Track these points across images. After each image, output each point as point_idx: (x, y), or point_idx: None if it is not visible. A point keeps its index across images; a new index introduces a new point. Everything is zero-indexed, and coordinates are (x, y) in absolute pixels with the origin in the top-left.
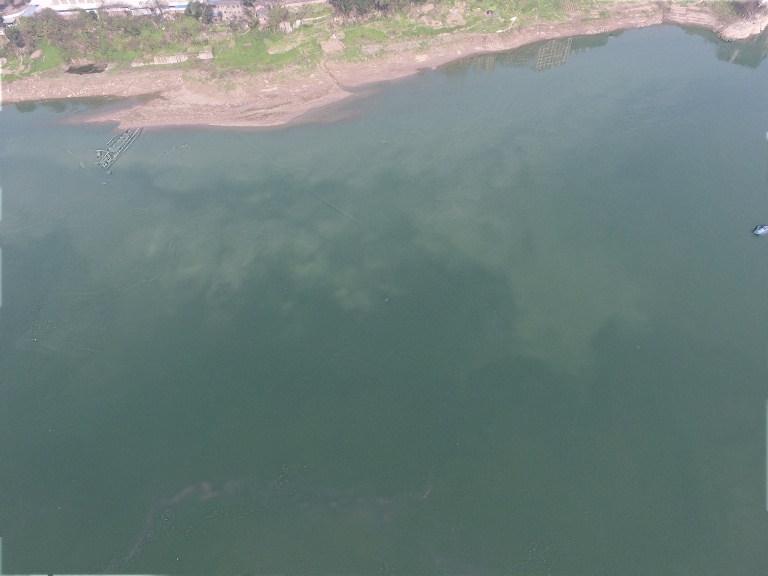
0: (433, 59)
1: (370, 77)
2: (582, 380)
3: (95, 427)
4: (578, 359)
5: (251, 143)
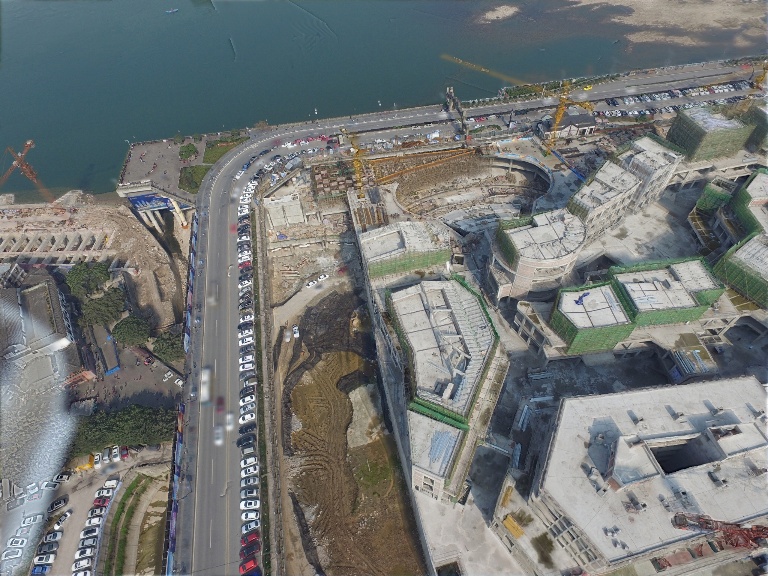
0: None
1: None
2: None
3: None
4: (26, 57)
5: None
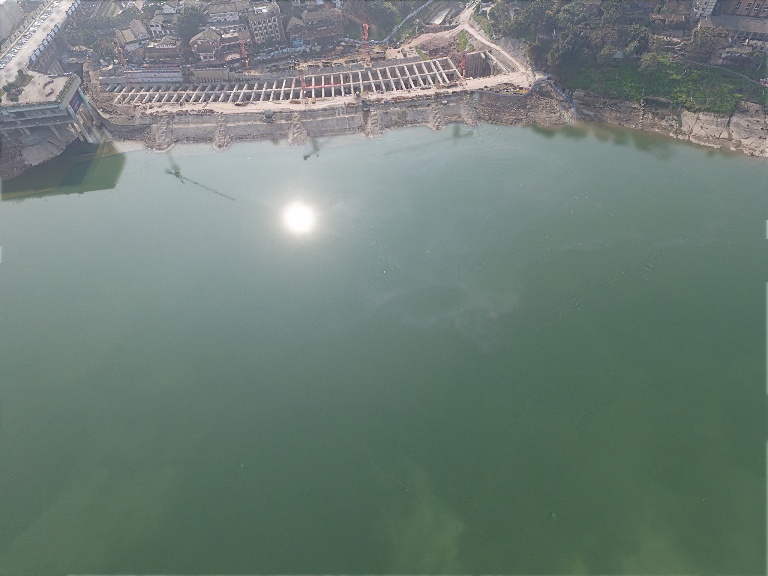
0: None
1: None
2: (318, 418)
3: (766, 325)
4: (316, 441)
5: None
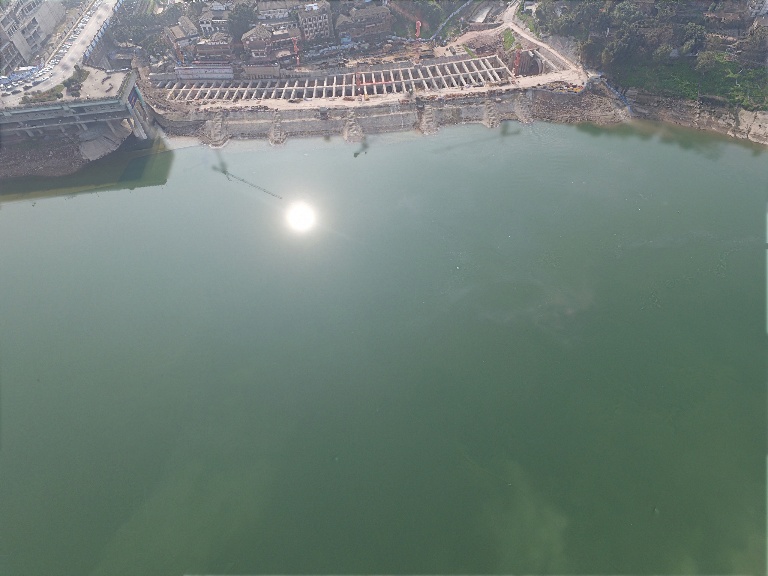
0: None
1: None
2: (408, 412)
3: None
4: (408, 436)
5: None
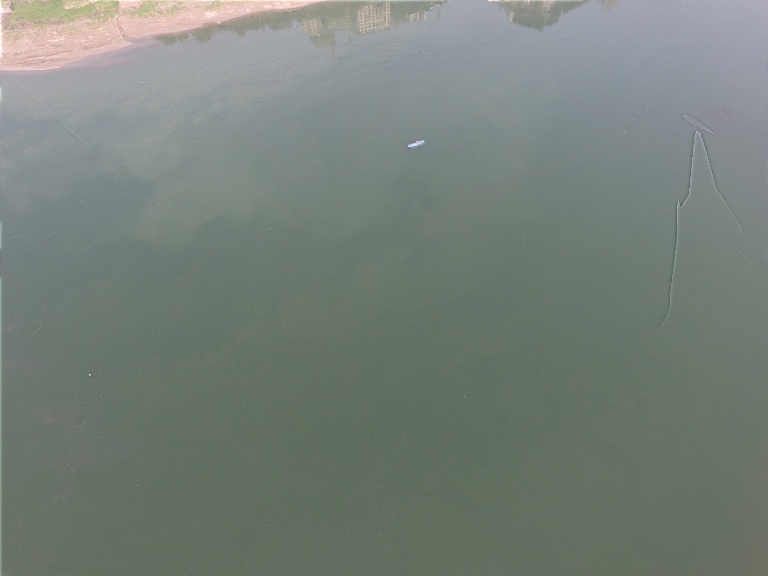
0: (221, 15)
1: (156, 30)
2: (210, 252)
3: None
4: (214, 238)
5: (22, 85)
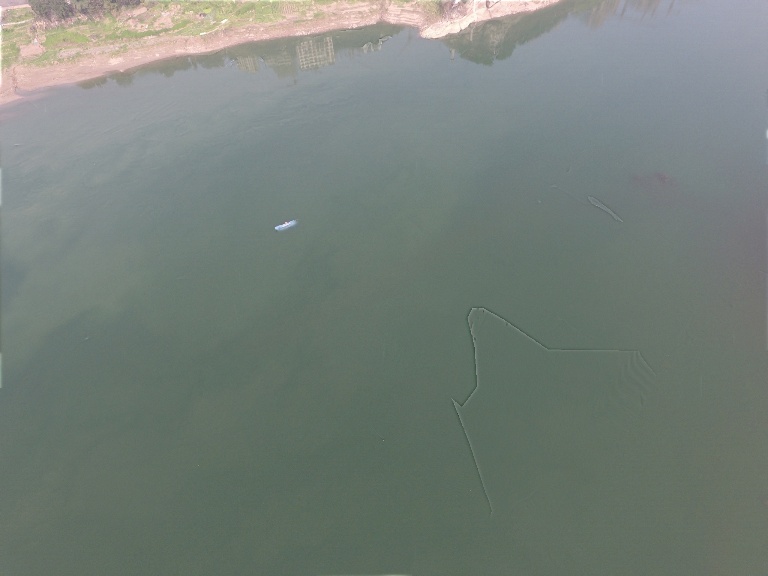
0: (127, 62)
1: (51, 80)
2: (6, 371)
3: None
4: (18, 351)
5: None
